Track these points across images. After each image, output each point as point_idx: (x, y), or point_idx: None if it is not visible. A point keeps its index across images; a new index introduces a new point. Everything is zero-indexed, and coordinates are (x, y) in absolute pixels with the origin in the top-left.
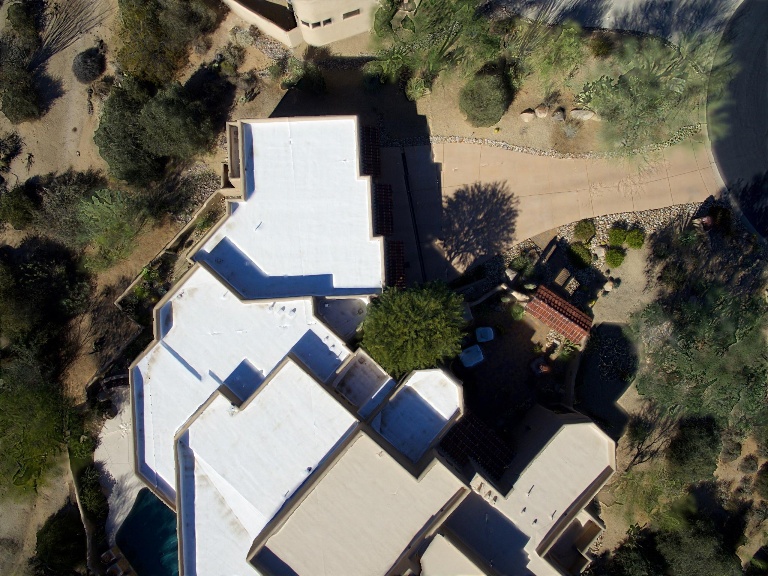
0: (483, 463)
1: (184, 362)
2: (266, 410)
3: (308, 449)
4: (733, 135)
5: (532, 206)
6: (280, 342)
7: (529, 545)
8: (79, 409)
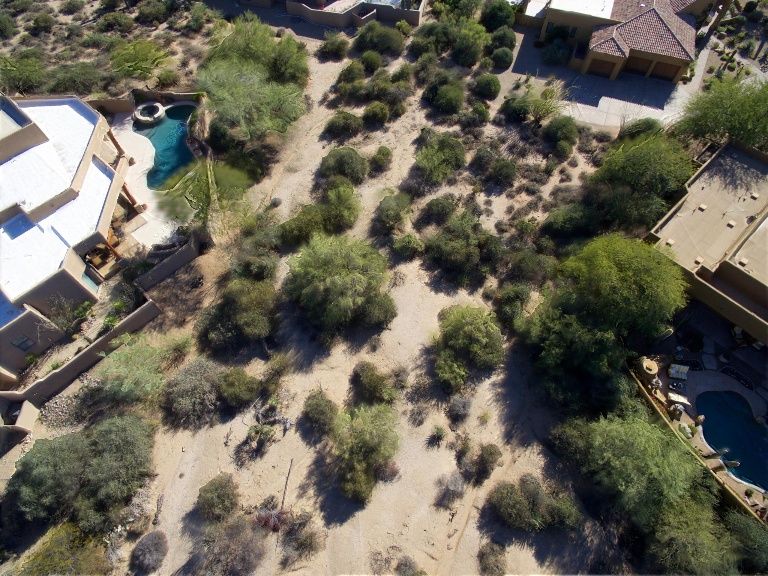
0: None
1: (61, 238)
2: (5, 205)
3: None
4: None
5: None
6: None
7: None
8: (198, 230)
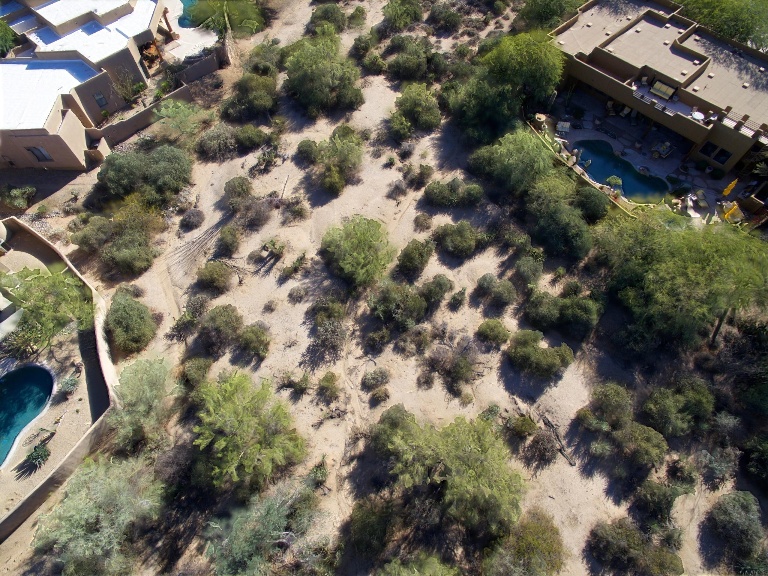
0: None
1: (124, 34)
2: None
3: (66, 3)
4: None
5: None
6: (67, 41)
7: None
8: (219, 47)
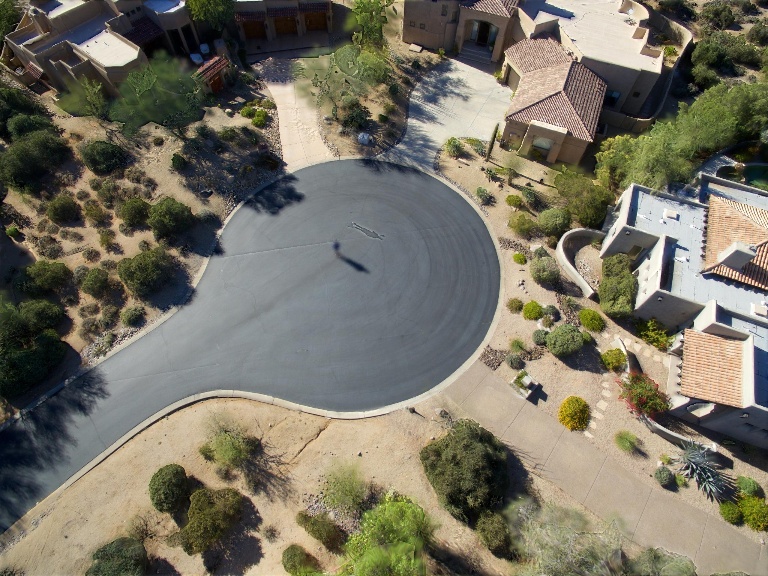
0: (130, 33)
1: None
2: None
3: None
4: (331, 173)
5: (288, 87)
6: None
7: (76, 45)
8: None
